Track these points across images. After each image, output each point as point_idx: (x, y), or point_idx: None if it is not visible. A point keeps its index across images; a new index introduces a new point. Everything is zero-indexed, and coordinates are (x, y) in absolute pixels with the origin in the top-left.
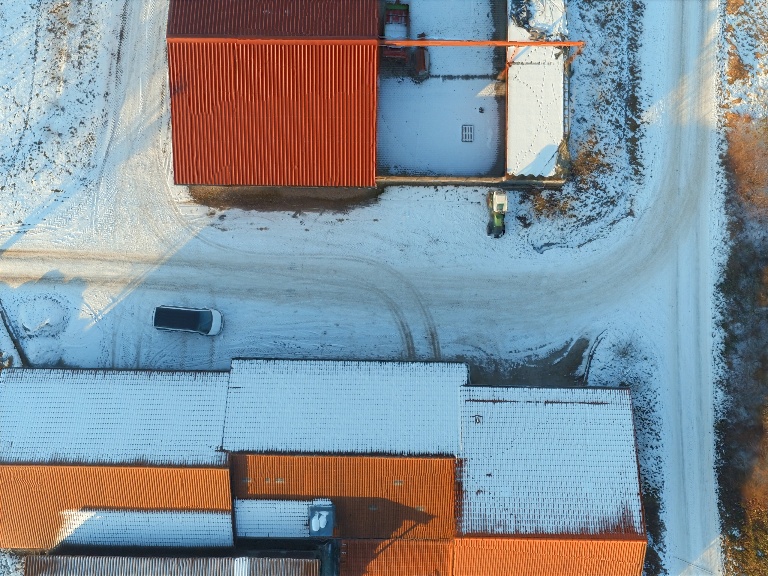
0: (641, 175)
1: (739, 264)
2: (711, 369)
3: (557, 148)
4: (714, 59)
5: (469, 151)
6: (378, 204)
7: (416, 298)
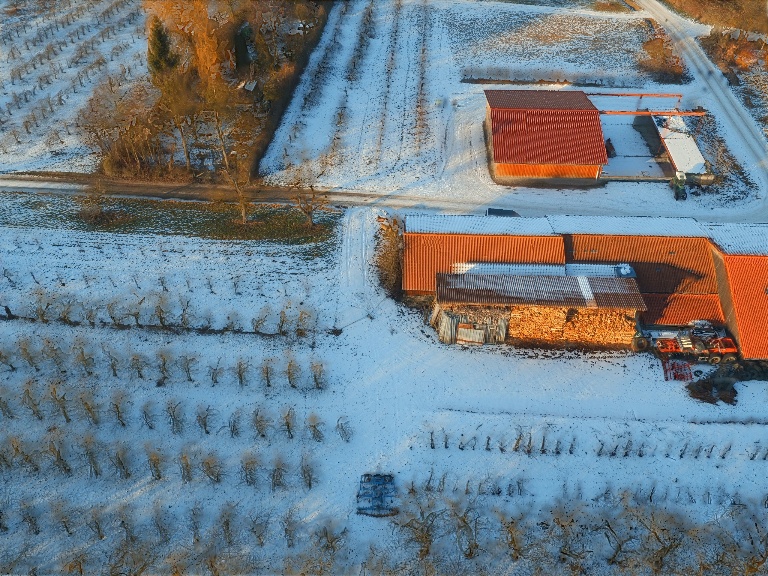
0: (756, 187)
1: None
2: None
3: (704, 164)
4: None
5: None
6: (606, 188)
7: None
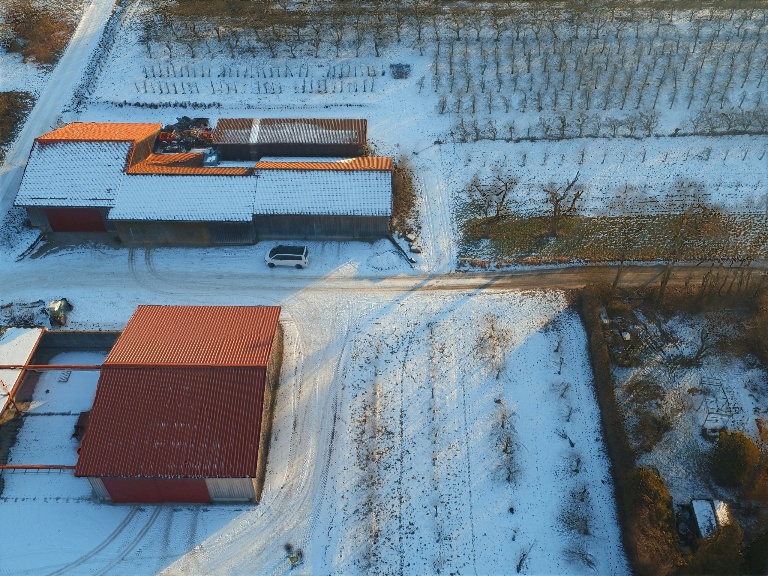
0: None
1: None
2: None
3: None
4: None
5: None
6: None
7: (136, 276)
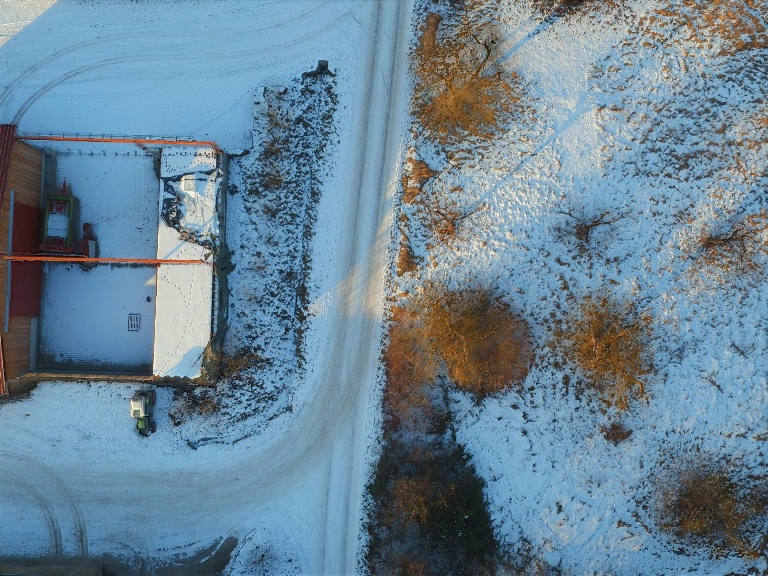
0: (303, 369)
1: (390, 465)
2: (355, 572)
3: (204, 350)
4: (386, 250)
5: (135, 340)
6: (31, 399)
7: (67, 494)
